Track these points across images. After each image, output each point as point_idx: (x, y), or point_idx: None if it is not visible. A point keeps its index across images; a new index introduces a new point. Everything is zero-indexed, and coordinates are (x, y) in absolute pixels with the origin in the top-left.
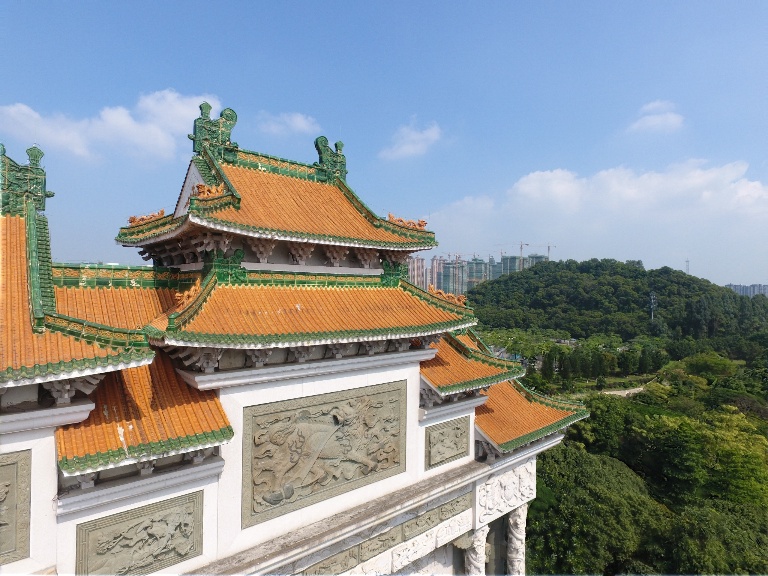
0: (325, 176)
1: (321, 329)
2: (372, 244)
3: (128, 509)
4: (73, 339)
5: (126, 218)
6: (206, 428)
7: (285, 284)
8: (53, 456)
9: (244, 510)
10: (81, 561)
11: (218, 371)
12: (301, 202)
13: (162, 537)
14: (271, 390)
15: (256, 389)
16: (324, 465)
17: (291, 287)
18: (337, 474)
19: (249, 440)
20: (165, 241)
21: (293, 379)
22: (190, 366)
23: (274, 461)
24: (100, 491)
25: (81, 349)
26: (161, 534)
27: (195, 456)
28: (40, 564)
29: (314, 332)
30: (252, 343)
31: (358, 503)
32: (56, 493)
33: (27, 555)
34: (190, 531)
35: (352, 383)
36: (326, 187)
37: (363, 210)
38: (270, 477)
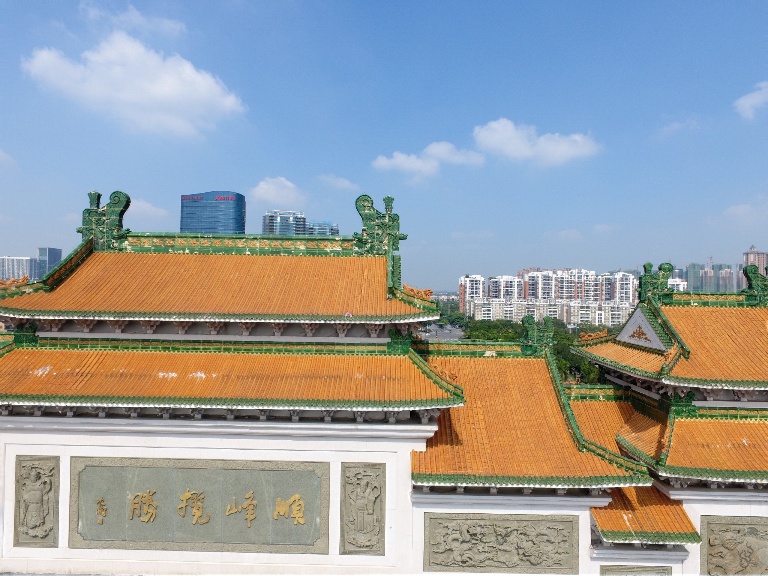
0: (755, 301)
1: None
2: None
3: (626, 565)
4: (600, 459)
5: None
6: (679, 529)
7: (729, 418)
8: (589, 522)
9: None
10: None
11: (682, 487)
12: (736, 338)
13: None
14: (723, 506)
15: (711, 503)
16: None
17: (734, 420)
18: None
19: (705, 540)
20: None
21: (742, 501)
22: (656, 474)
23: (725, 561)
24: (615, 551)
25: (608, 467)
26: None
27: None
28: None
29: (766, 471)
30: (715, 477)
31: None
32: (590, 543)
33: (577, 573)
34: None
35: None
36: (757, 312)
37: None
38: (722, 572)
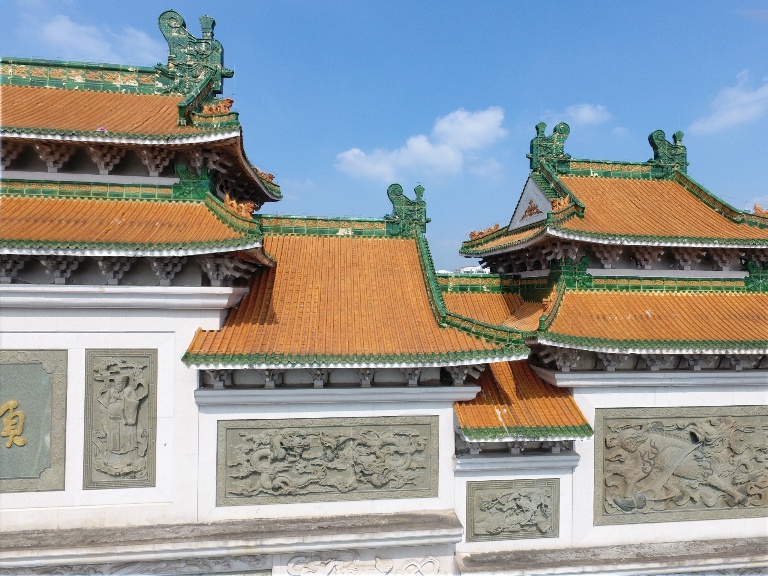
0: (662, 172)
1: (679, 337)
2: (737, 243)
3: (501, 479)
4: (466, 334)
5: (468, 233)
6: (566, 422)
7: (630, 289)
8: (452, 424)
9: (596, 507)
10: (469, 511)
11: (572, 371)
12: (640, 204)
13: (527, 511)
14: (622, 395)
15: (607, 392)
16: (679, 483)
17: (637, 292)
18: (695, 497)
19: (600, 441)
20: (511, 252)
21: (645, 387)
22: (543, 364)
23: (625, 467)
24: (484, 459)
25: (473, 342)
26: (527, 508)
27: (553, 446)
28: (444, 505)
29: (673, 340)
30: (610, 347)
31: (721, 536)
32: (454, 453)
33: (437, 495)
34: (549, 513)
35: (713, 400)
36: (664, 184)
37: (716, 204)
38: (621, 482)
